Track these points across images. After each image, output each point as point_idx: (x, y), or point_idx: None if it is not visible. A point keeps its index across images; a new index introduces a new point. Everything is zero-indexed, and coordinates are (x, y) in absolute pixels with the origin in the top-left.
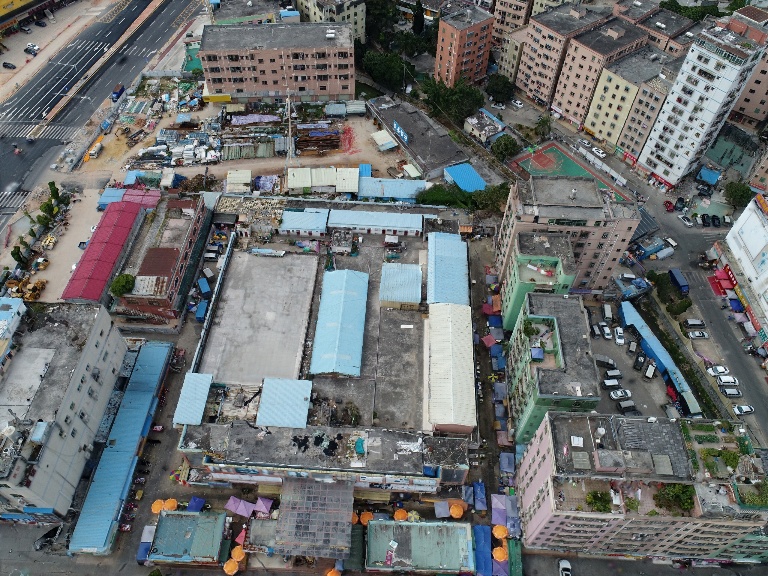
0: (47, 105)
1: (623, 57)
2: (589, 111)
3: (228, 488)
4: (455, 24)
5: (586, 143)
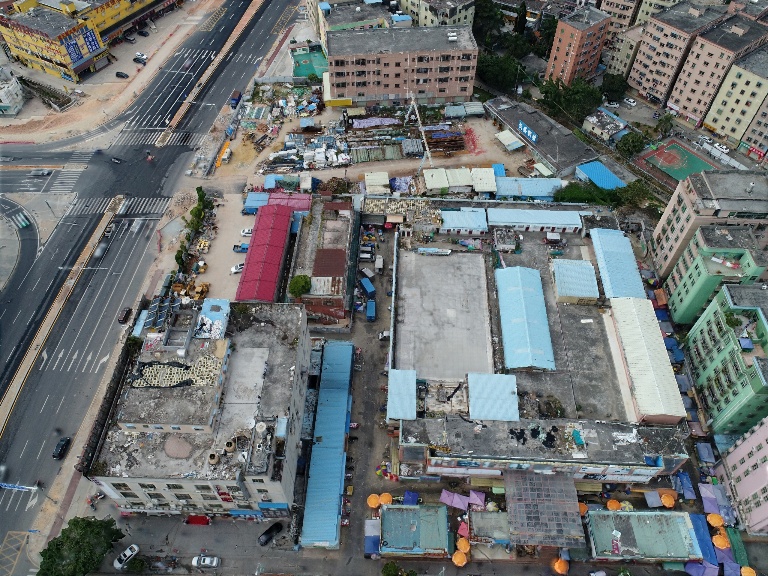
0: (168, 113)
1: (749, 53)
2: (711, 107)
3: (435, 482)
4: (574, 25)
5: (708, 139)
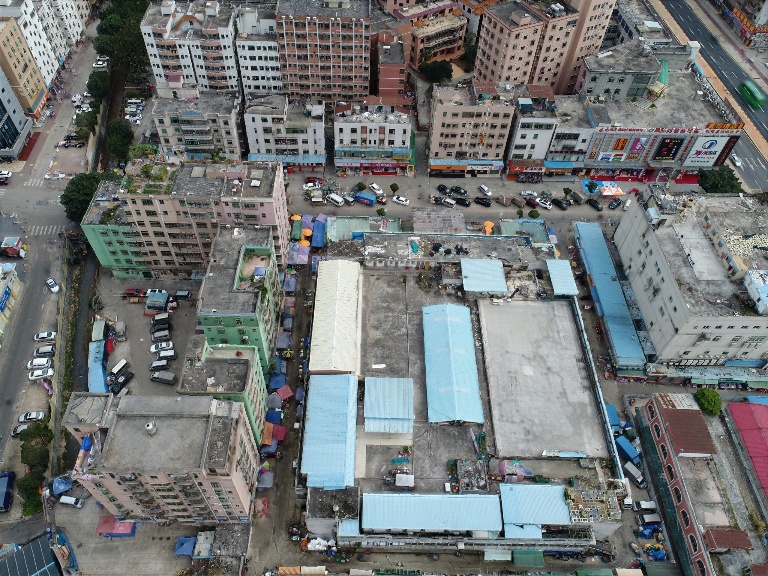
0: None
1: None
2: None
3: None
4: None
5: None
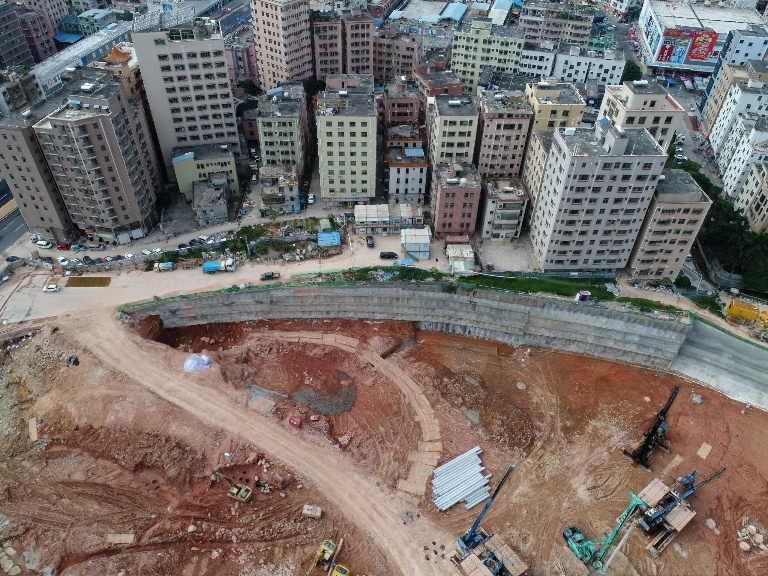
0: None
1: None
2: None
3: None
4: None
5: None
